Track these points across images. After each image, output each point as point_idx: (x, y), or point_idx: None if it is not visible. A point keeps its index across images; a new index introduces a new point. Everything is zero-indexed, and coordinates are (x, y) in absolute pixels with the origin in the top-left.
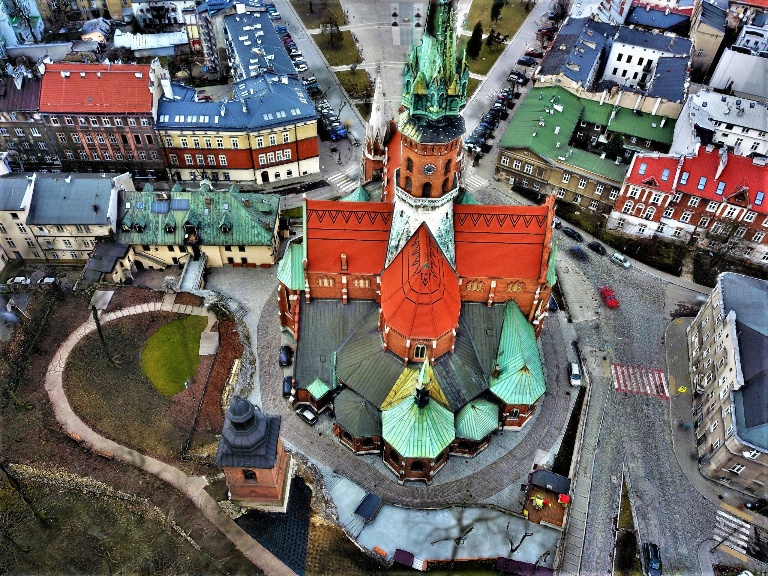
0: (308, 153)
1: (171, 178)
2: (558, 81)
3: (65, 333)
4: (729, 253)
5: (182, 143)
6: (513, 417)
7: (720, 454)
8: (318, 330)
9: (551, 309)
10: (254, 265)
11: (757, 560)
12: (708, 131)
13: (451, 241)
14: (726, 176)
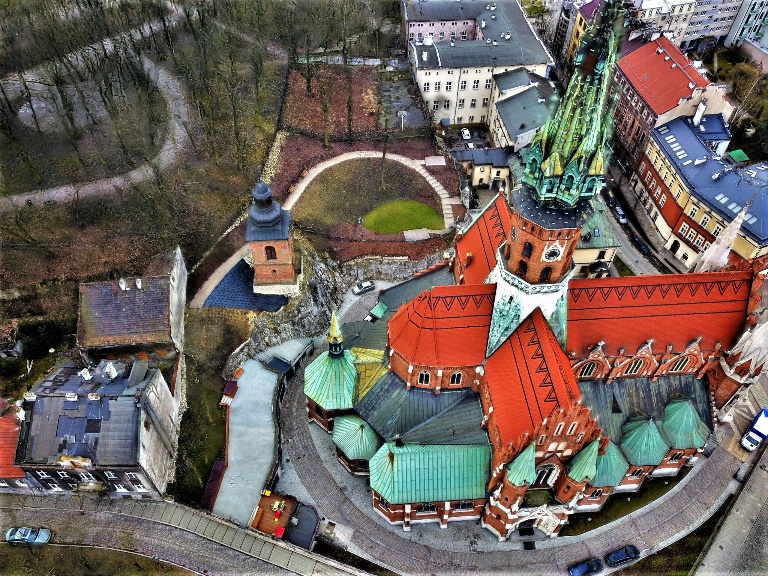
0: None
1: None
2: None
3: (397, 151)
4: None
5: (655, 160)
6: None
7: None
8: None
9: (569, 567)
10: None
11: None
12: None
13: (500, 327)
14: None
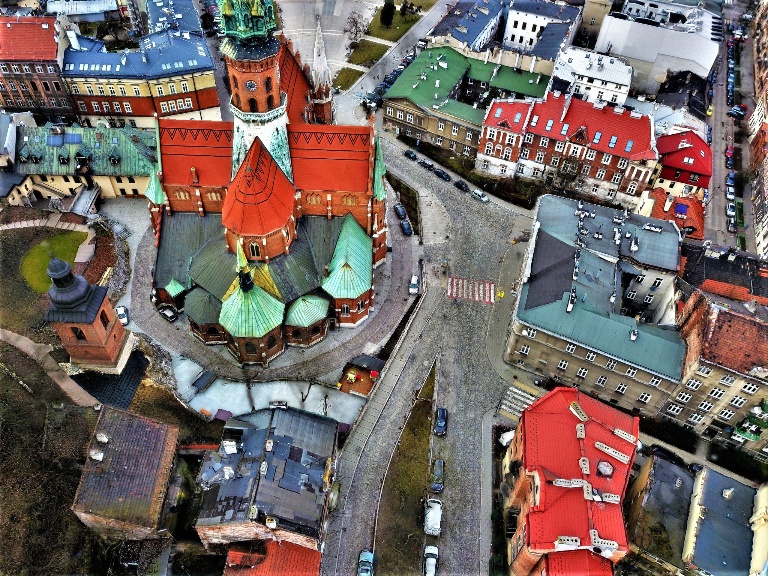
0: (209, 103)
1: (80, 124)
2: (447, 42)
3: None
4: (580, 191)
5: (88, 90)
6: (346, 314)
7: (511, 338)
8: (177, 239)
9: (406, 233)
10: (144, 196)
11: None
12: (565, 82)
13: (285, 156)
14: (570, 118)
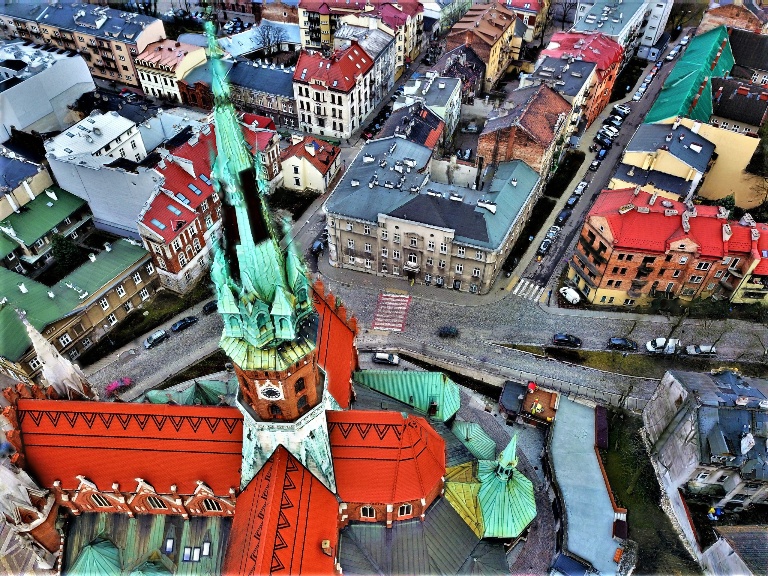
0: None
1: None
2: None
3: None
4: None
5: None
6: None
7: (488, 271)
8: None
9: None
10: None
11: (548, 283)
12: (120, 161)
13: None
14: (196, 170)
